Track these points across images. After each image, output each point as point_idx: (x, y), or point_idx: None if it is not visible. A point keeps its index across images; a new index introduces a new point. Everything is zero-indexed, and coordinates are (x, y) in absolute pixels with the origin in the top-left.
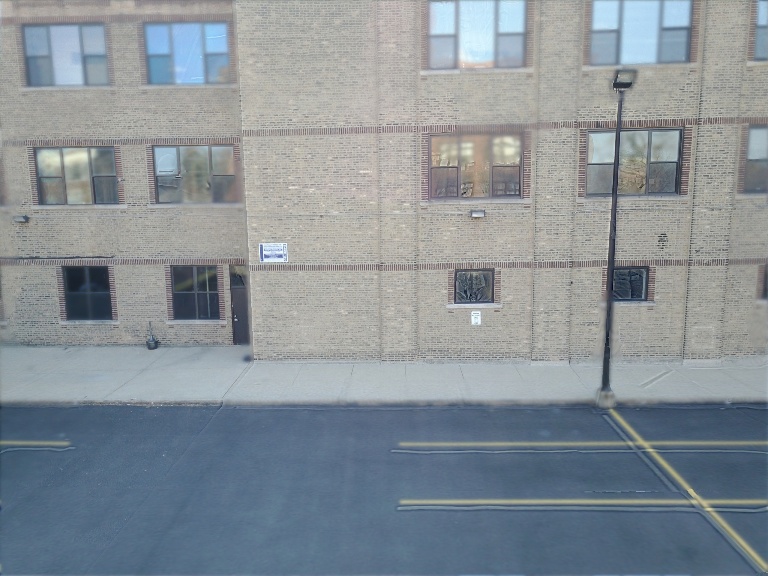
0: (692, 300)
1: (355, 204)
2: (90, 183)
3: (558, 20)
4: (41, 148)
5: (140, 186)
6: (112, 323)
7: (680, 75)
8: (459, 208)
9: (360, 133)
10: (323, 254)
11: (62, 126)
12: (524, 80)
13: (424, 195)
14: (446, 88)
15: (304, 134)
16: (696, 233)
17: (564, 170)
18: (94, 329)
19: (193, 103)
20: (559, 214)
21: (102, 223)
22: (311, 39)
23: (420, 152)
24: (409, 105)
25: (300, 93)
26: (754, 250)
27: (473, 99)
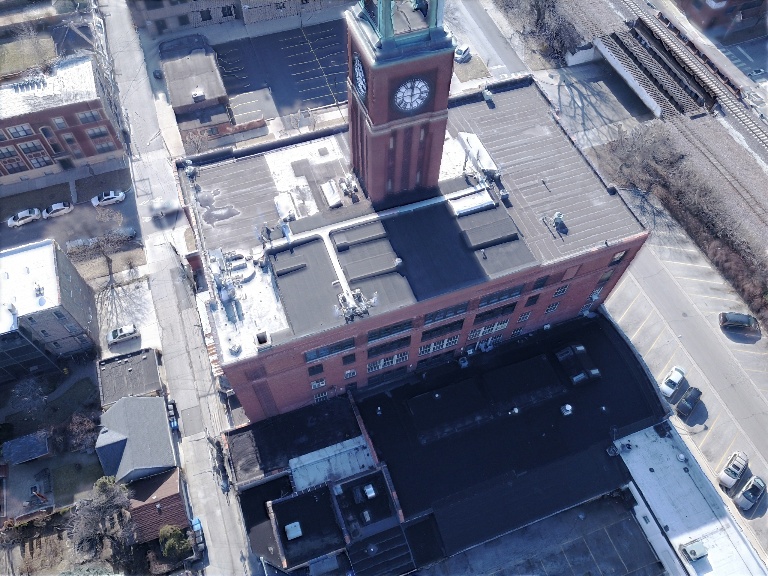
0: None
1: None
2: None
3: None
4: None
5: None
6: None
7: None
8: None
9: None
10: (255, 5)
11: None
12: None
13: None
14: None
15: None
16: None
17: None
18: None
19: None
20: None
21: None
22: None
23: None
24: None
25: None
26: None
27: None
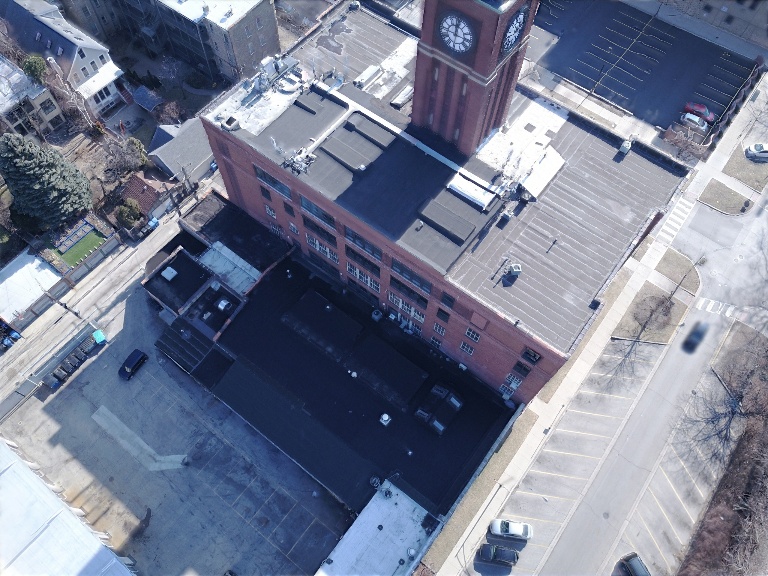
0: (691, 4)
1: None
2: None
3: None
4: None
5: None
6: None
7: None
8: None
9: None
10: None
11: None
12: None
13: None
14: None
15: None
16: None
17: None
18: None
19: None
20: None
21: None
22: None
23: None
24: None
25: None
26: None
27: None
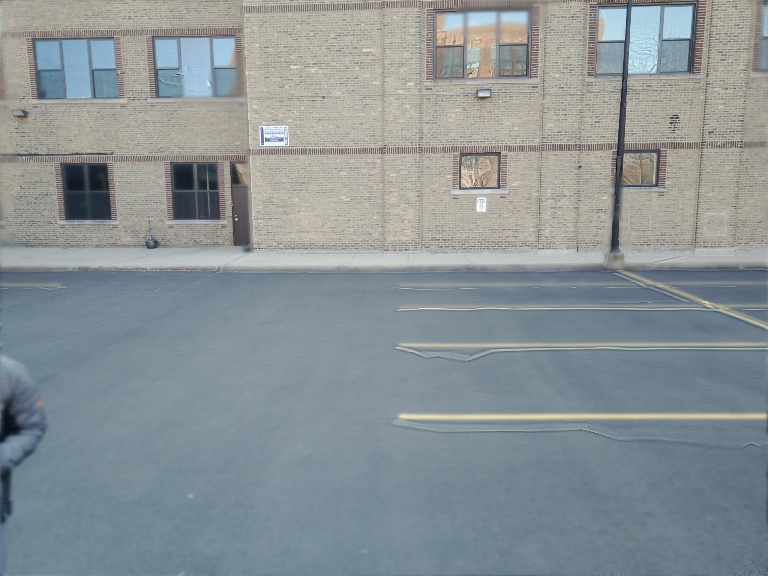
0: (704, 185)
1: (358, 84)
2: (89, 76)
3: None
4: (40, 40)
5: (140, 79)
6: (111, 223)
7: None
8: (465, 88)
9: (364, 9)
10: (325, 137)
11: (61, 16)
12: None
13: (429, 75)
14: None
15: (306, 10)
16: (709, 113)
17: (573, 47)
18: (93, 229)
19: None
20: (568, 94)
21: (101, 118)
22: None
23: (425, 29)
24: None
25: None
26: None
27: None
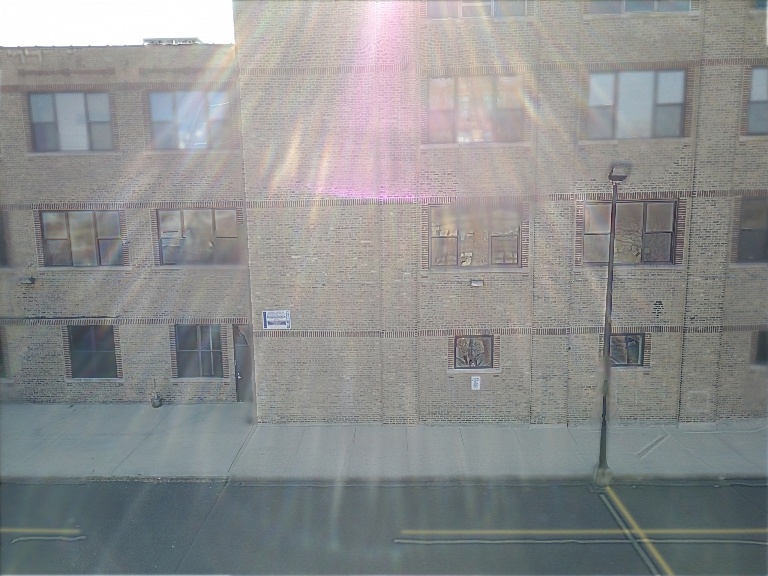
0: (687, 366)
1: (357, 273)
2: (95, 245)
3: (555, 97)
4: (47, 211)
5: (144, 248)
6: (117, 381)
7: (674, 149)
8: (459, 277)
9: (361, 205)
10: (325, 321)
11: (67, 190)
12: (522, 154)
13: (424, 264)
14: (445, 161)
15: (306, 206)
16: (691, 301)
17: (561, 241)
18: (99, 387)
19: (197, 168)
20: (557, 283)
21: (107, 284)
22: (313, 114)
23: (420, 223)
24: (409, 178)
25: (302, 166)
26: (747, 317)
27: (472, 172)
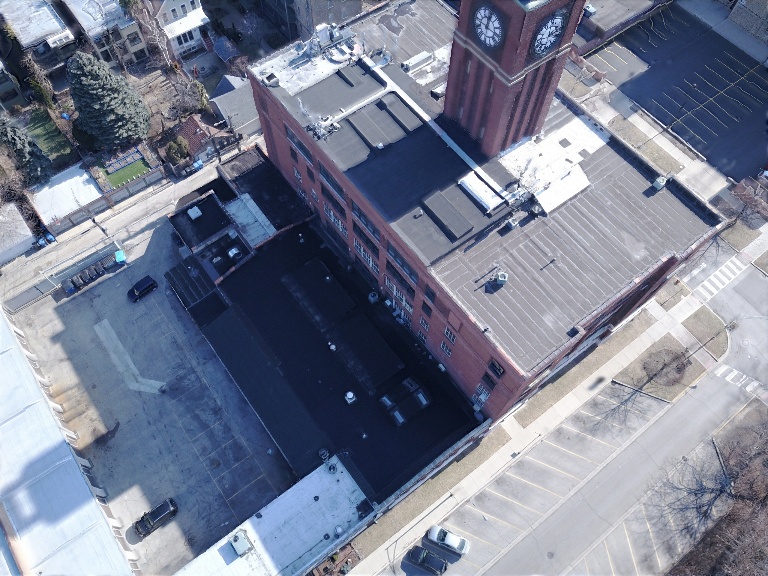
0: None
1: (763, 3)
2: None
3: None
4: None
5: None
6: None
7: None
8: None
9: None
10: (751, 8)
11: None
12: None
13: None
14: None
15: None
16: None
17: None
18: None
19: None
20: None
21: None
22: None
23: None
24: None
25: None
26: None
27: None
